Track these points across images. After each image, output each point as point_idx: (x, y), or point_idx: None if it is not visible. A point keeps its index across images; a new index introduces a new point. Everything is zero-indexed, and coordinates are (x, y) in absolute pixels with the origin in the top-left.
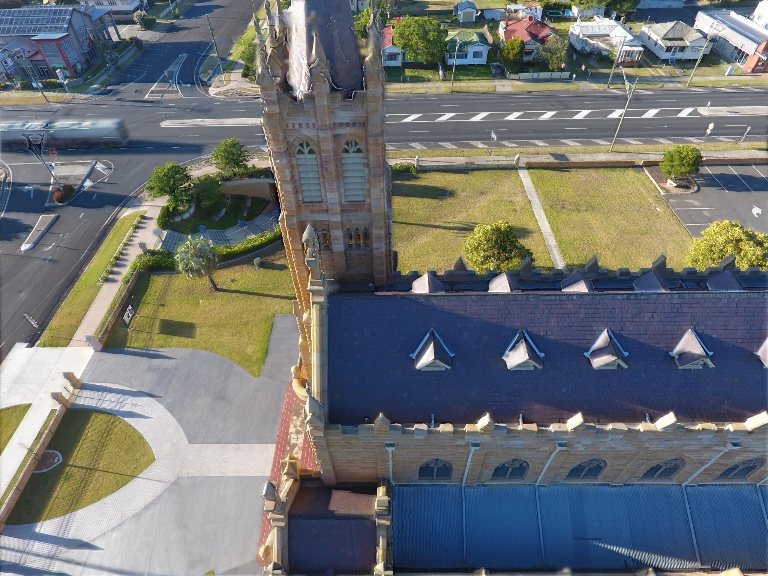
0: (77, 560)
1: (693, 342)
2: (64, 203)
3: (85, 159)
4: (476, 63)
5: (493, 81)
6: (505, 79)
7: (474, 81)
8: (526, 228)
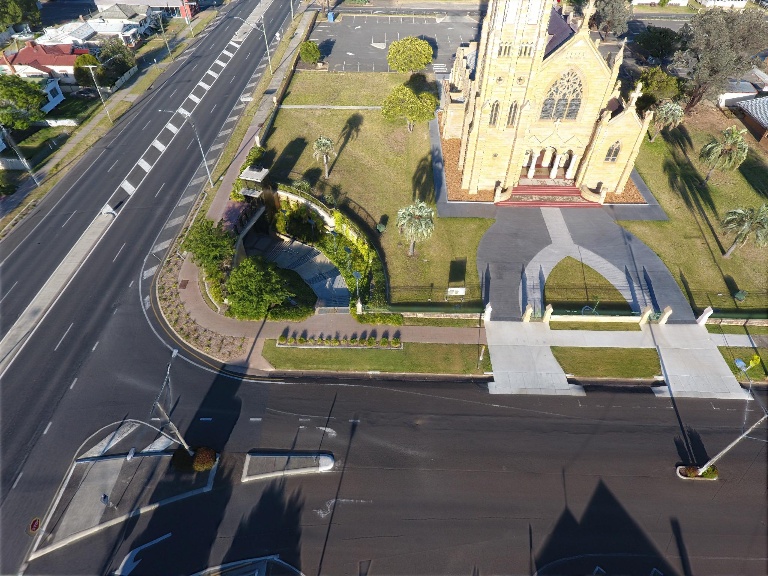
0: (636, 275)
1: (556, 8)
2: (216, 456)
3: (54, 488)
4: (58, 102)
5: (110, 100)
6: (112, 94)
7: (99, 109)
8: (353, 113)
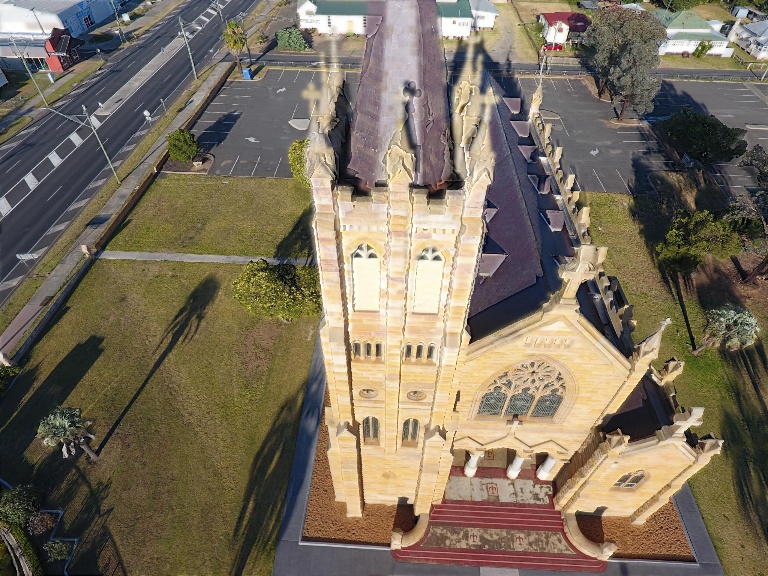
0: None
1: (527, 148)
2: None
3: None
4: None
5: None
6: None
7: None
8: (209, 273)
